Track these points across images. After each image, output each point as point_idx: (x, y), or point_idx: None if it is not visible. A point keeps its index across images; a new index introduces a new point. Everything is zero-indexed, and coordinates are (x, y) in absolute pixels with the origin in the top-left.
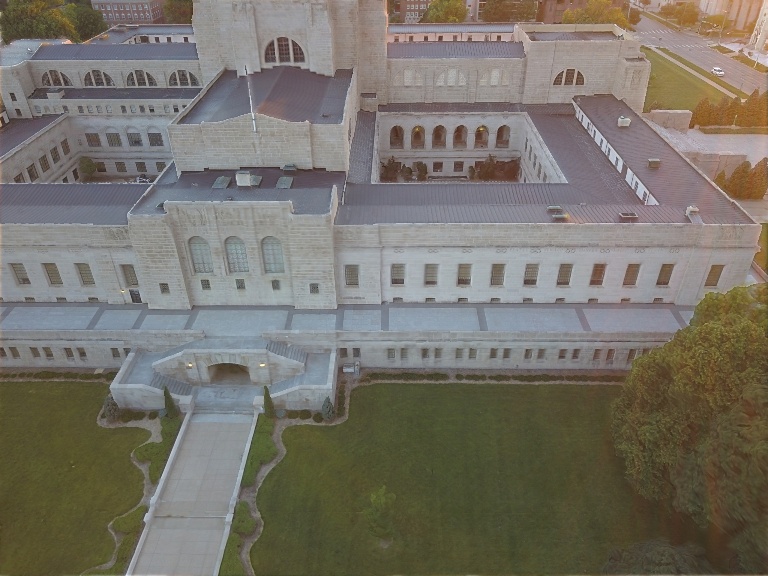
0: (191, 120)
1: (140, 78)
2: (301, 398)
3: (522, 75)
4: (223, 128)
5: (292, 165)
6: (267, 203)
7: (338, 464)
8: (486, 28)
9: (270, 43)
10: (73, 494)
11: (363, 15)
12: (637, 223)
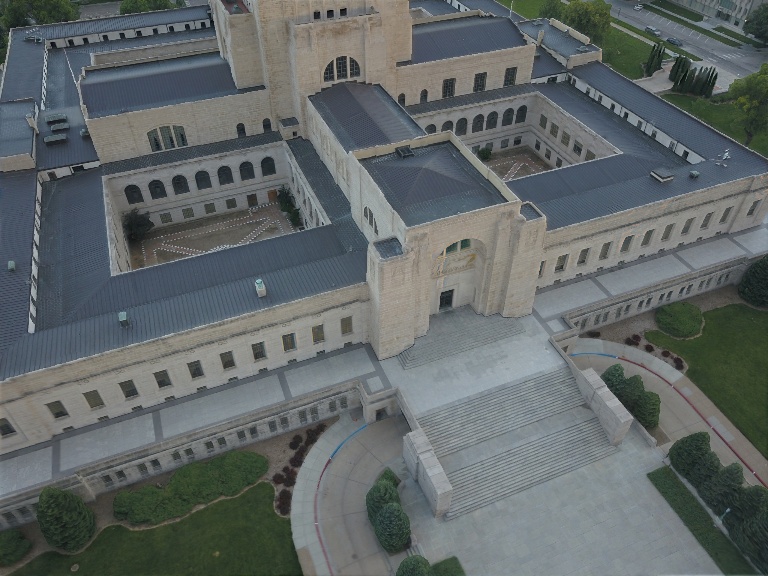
0: (111, 71)
1: None
2: None
3: None
4: None
5: (83, 131)
6: None
7: None
8: (690, 132)
9: None
10: None
11: (289, 45)
12: None
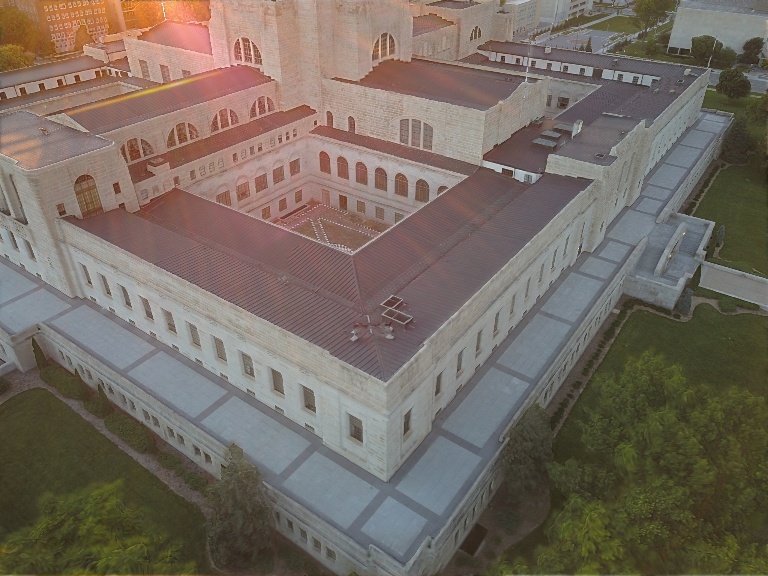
0: None
1: (222, 119)
2: (708, 238)
3: (457, 37)
4: (511, 102)
5: None
6: (640, 126)
7: (759, 251)
8: None
9: (376, 41)
10: (759, 342)
11: None
12: (694, 82)
